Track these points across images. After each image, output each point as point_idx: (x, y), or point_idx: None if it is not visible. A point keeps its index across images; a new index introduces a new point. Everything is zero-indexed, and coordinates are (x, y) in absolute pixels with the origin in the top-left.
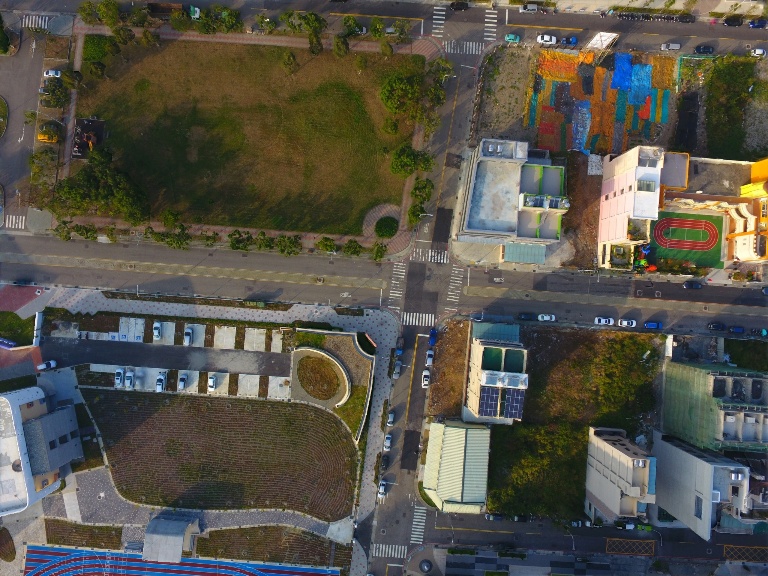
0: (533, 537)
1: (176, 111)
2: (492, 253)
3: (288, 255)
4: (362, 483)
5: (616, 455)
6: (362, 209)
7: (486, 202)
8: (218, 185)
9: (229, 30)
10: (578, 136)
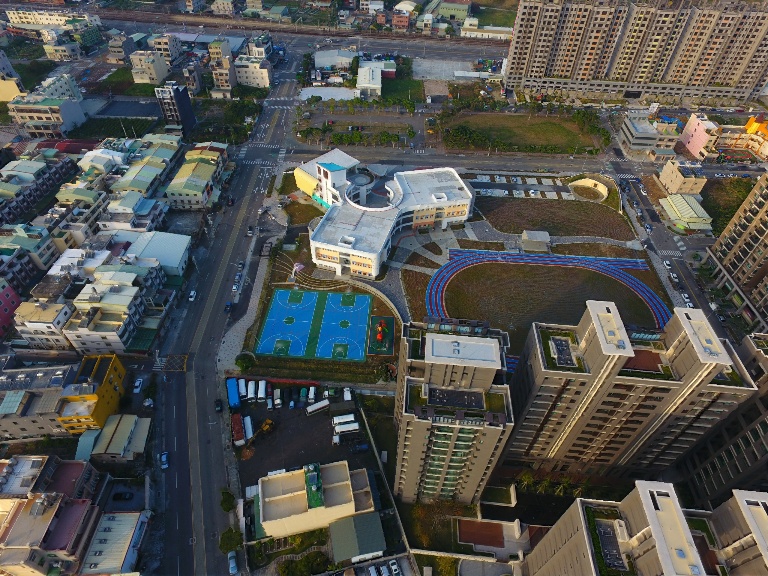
0: None
1: (483, 128)
2: None
3: (556, 150)
4: None
5: None
6: (578, 148)
7: None
8: None
9: (498, 112)
10: None
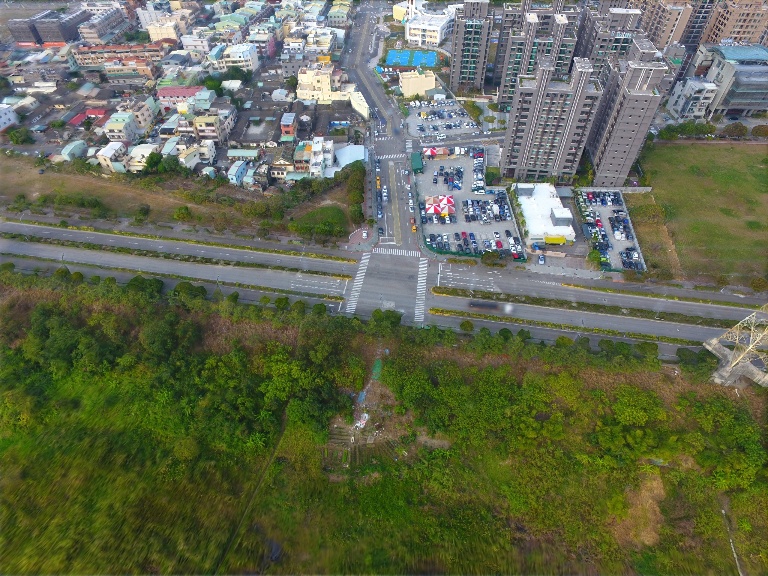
0: None
1: None
2: None
3: None
4: None
5: None
6: None
7: None
8: None
9: None
10: None
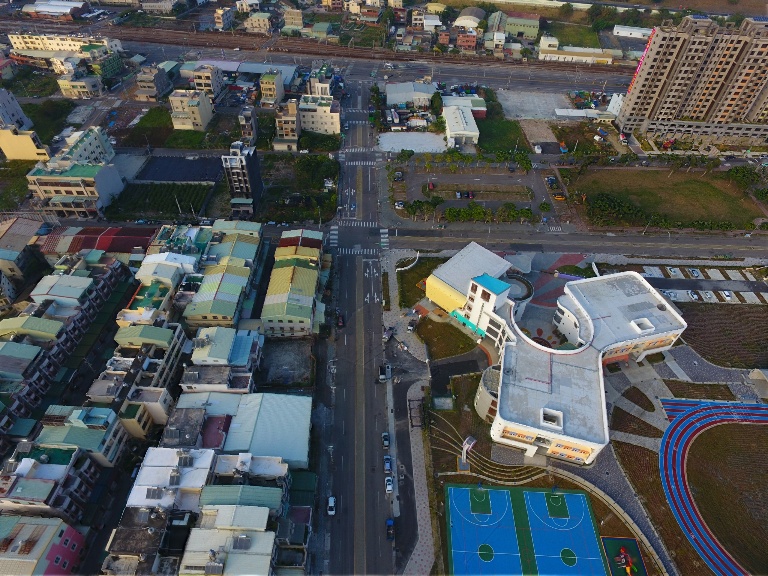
0: None
1: (617, 190)
2: None
3: (733, 228)
4: None
5: None
6: (748, 220)
7: None
8: (660, 213)
9: (626, 166)
10: None
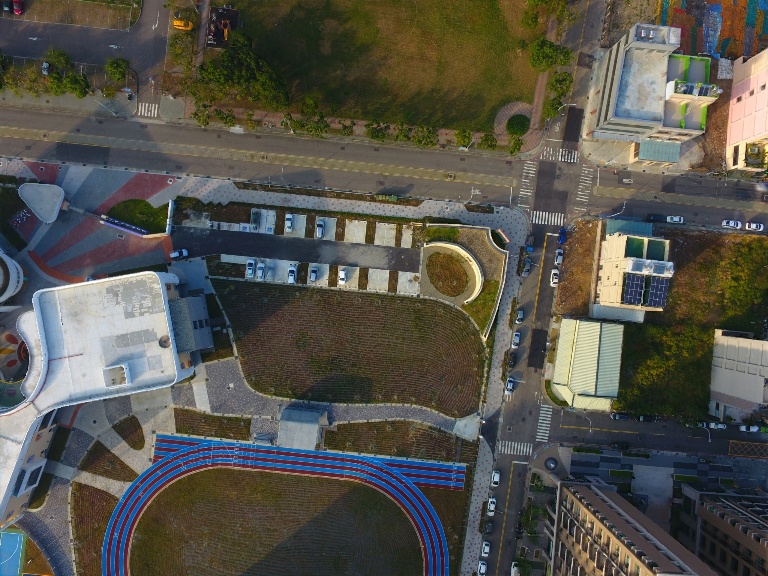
0: (657, 438)
1: (310, 3)
2: (622, 154)
3: (426, 145)
4: (489, 380)
5: (757, 346)
6: (494, 106)
7: (632, 92)
8: (351, 78)
9: None
10: (709, 39)
